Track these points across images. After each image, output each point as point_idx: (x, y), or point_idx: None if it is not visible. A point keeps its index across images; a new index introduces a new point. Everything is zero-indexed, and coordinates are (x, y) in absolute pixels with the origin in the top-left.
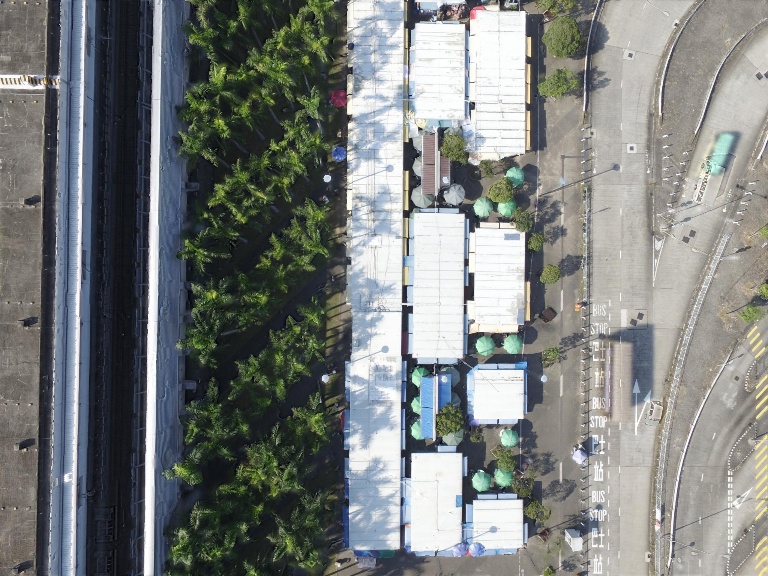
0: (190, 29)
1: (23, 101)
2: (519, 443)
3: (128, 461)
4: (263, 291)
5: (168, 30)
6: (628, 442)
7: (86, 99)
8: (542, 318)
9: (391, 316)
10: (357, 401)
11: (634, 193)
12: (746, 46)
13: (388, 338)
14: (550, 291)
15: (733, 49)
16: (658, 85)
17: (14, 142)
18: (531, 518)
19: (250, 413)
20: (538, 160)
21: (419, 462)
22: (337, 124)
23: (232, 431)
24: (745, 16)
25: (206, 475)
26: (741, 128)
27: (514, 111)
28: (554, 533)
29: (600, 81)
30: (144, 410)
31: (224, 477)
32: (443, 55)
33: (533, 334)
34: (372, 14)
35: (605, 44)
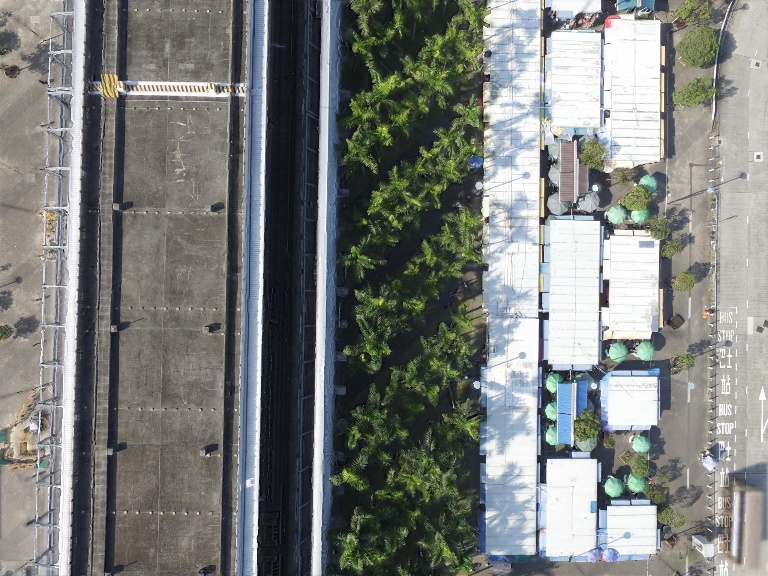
0: (352, 37)
1: (206, 108)
2: None
3: (288, 466)
4: (419, 298)
5: None
6: (754, 449)
7: None
8: (671, 325)
9: (528, 322)
10: (494, 407)
11: (761, 201)
12: None
13: (525, 344)
14: (678, 298)
15: None
16: None
17: (197, 149)
18: (664, 524)
19: (404, 419)
20: (667, 168)
21: (555, 468)
22: (469, 131)
23: (392, 437)
24: None
25: None
26: None
27: (649, 119)
28: (681, 539)
29: (728, 90)
30: (305, 415)
31: (373, 482)
32: (579, 63)
33: (661, 341)
34: (509, 22)
35: (733, 53)
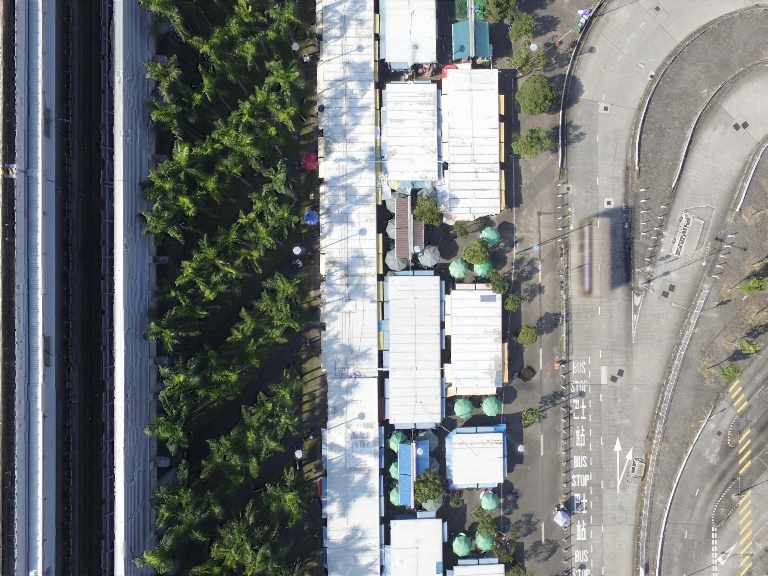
0: (153, 105)
1: None
2: (500, 504)
3: (98, 545)
4: (233, 368)
5: (134, 98)
6: (610, 500)
7: (46, 184)
8: (521, 378)
9: (367, 382)
10: (334, 469)
11: (612, 248)
12: (723, 97)
13: (364, 405)
14: (529, 350)
15: (709, 101)
16: (634, 138)
17: None
18: None
19: (223, 492)
20: (514, 217)
21: (398, 529)
22: (309, 185)
23: (204, 513)
24: (721, 66)
25: (180, 552)
26: (719, 180)
27: (488, 171)
28: None
29: (575, 136)
30: None
31: (198, 555)
32: (415, 115)
33: (512, 393)
34: (342, 75)
35: (580, 98)
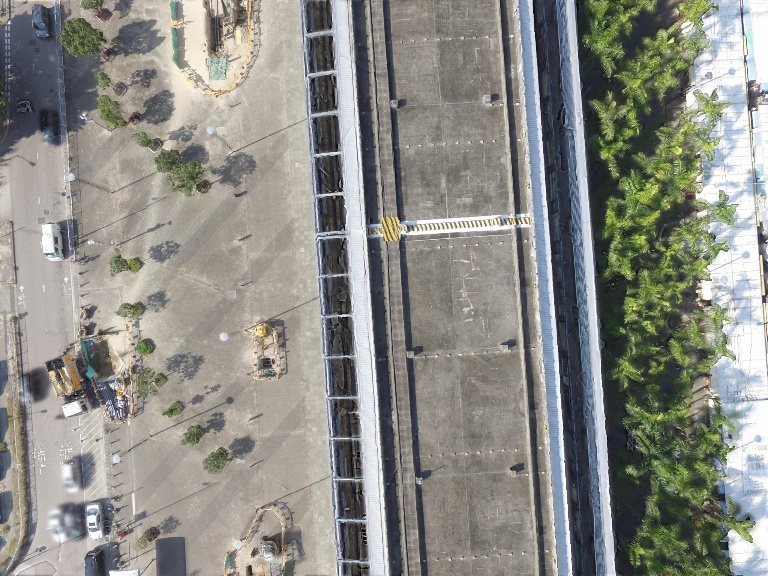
0: (597, 143)
1: (490, 243)
2: None
3: None
4: (679, 401)
5: None
6: None
7: None
8: None
9: (761, 405)
10: (732, 493)
11: None
12: None
13: (760, 427)
14: None
15: None
16: None
17: (483, 286)
18: None
19: None
20: None
21: None
22: (675, 210)
23: None
24: None
25: None
26: None
27: None
28: None
29: None
30: None
31: None
32: None
33: None
34: None
35: None
